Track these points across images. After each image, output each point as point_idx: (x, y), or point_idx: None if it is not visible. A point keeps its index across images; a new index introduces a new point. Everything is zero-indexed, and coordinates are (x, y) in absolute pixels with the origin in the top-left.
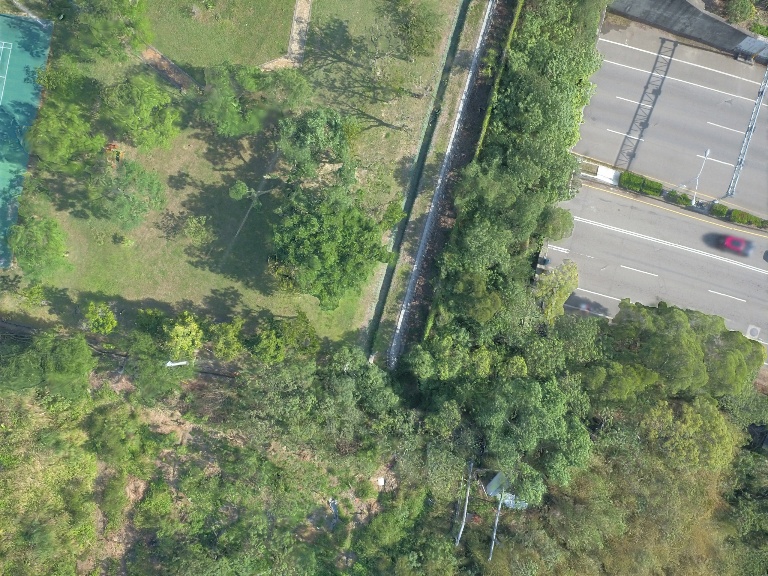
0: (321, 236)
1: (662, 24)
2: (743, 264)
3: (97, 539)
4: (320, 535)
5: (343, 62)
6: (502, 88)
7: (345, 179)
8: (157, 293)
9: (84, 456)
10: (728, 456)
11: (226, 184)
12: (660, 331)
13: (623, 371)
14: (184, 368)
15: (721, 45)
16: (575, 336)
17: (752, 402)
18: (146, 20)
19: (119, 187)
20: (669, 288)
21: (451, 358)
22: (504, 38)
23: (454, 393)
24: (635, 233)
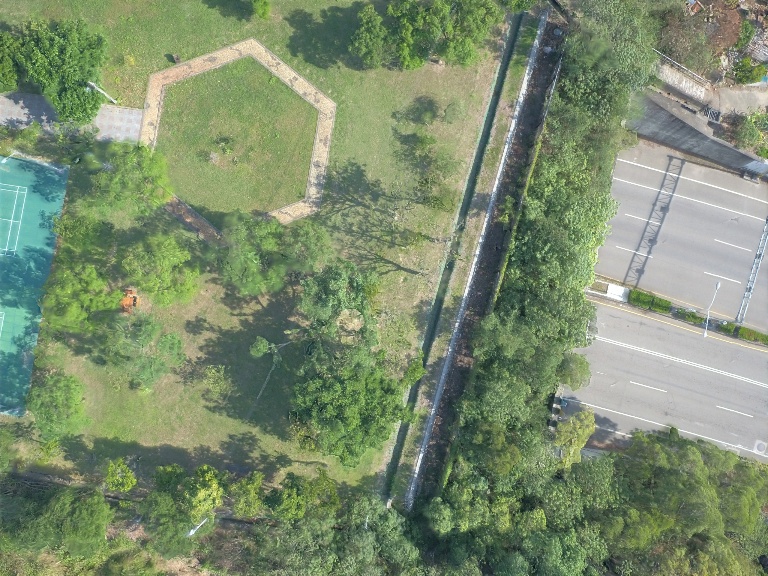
0: (344, 399)
1: (670, 143)
2: (750, 380)
3: None
4: None
5: (361, 206)
6: (519, 235)
7: (367, 341)
8: (174, 439)
9: None
10: None
11: (244, 329)
12: (673, 466)
13: (640, 519)
14: (205, 526)
15: (728, 164)
16: (592, 480)
17: (764, 536)
18: (163, 164)
19: (136, 334)
20: (678, 404)
21: (472, 514)
22: (520, 181)
23: (473, 542)
24: (644, 349)
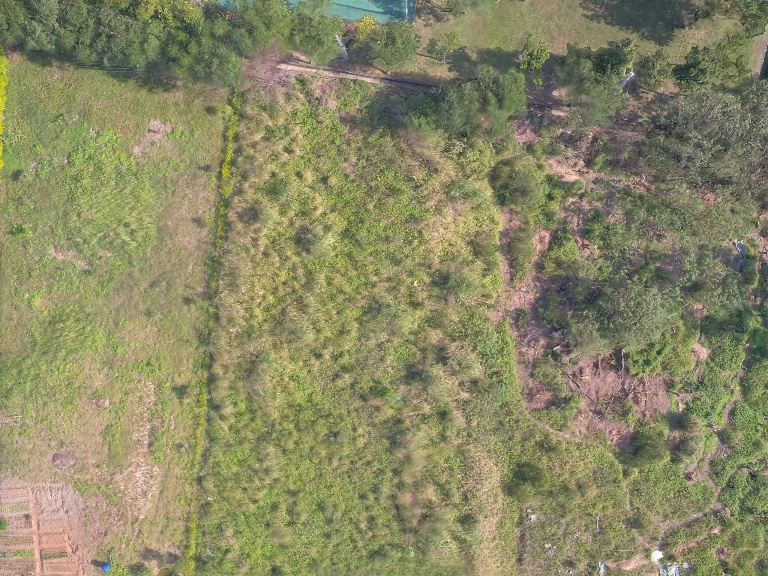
0: None
1: None
2: None
3: (505, 290)
4: None
5: None
6: None
7: None
8: (555, 47)
9: (493, 207)
10: None
11: None
12: None
13: None
14: None
15: None
16: None
17: None
18: None
19: None
20: None
21: None
22: None
23: None
24: None
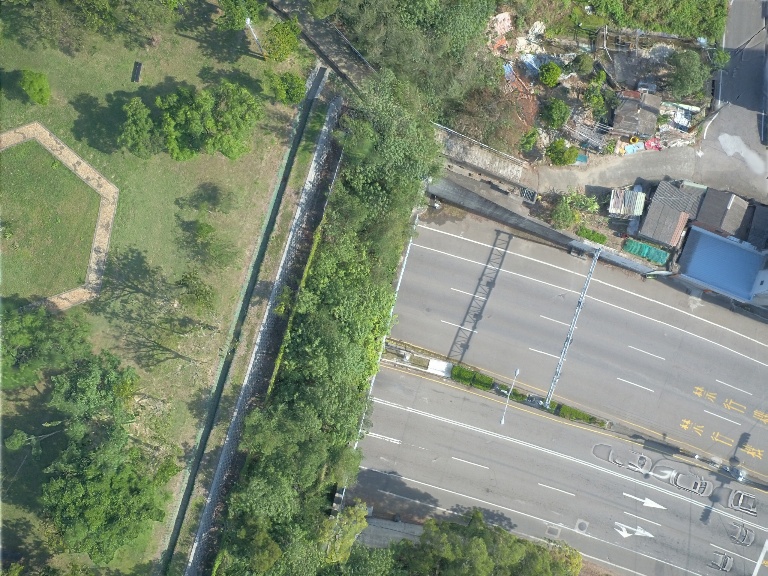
0: (88, 499)
1: (497, 217)
2: (573, 458)
3: None
4: None
5: (140, 293)
6: (295, 326)
7: (114, 440)
8: None
9: None
10: None
11: (20, 414)
12: None
13: None
14: None
15: (555, 239)
16: (365, 574)
17: None
18: None
19: None
20: (499, 481)
21: None
22: None
23: None
24: (467, 425)
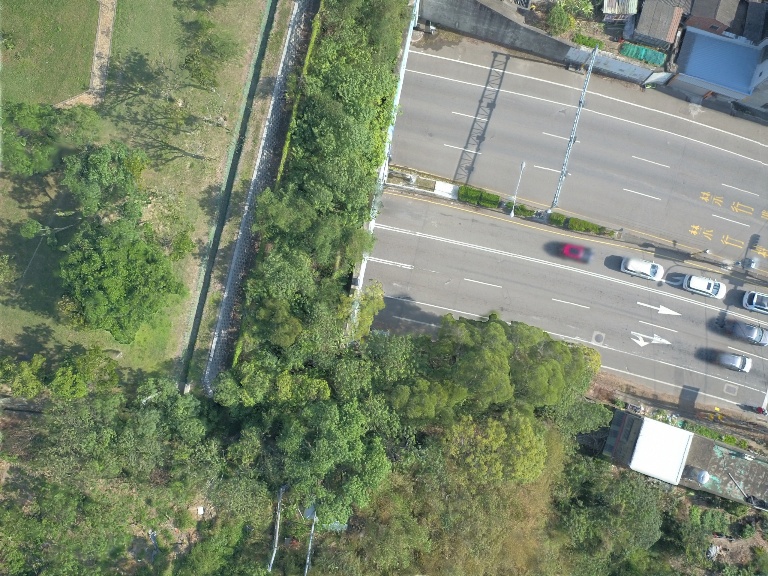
0: (106, 271)
1: (493, 38)
2: (585, 271)
3: None
4: (141, 567)
5: None
6: (300, 113)
7: (129, 213)
8: None
9: None
10: (541, 467)
11: None
12: (481, 345)
13: (430, 388)
14: None
15: (552, 56)
16: (386, 355)
17: (575, 410)
18: None
19: None
20: (513, 299)
21: (249, 385)
22: None
23: None
24: (477, 246)
